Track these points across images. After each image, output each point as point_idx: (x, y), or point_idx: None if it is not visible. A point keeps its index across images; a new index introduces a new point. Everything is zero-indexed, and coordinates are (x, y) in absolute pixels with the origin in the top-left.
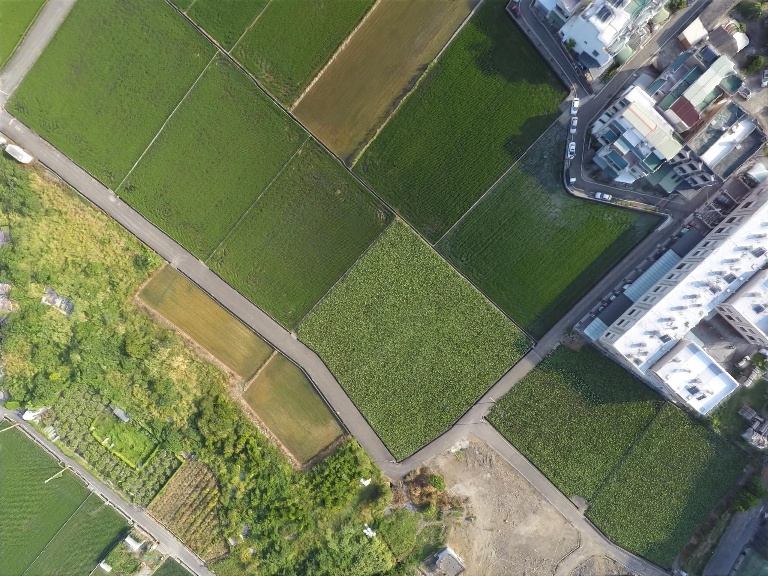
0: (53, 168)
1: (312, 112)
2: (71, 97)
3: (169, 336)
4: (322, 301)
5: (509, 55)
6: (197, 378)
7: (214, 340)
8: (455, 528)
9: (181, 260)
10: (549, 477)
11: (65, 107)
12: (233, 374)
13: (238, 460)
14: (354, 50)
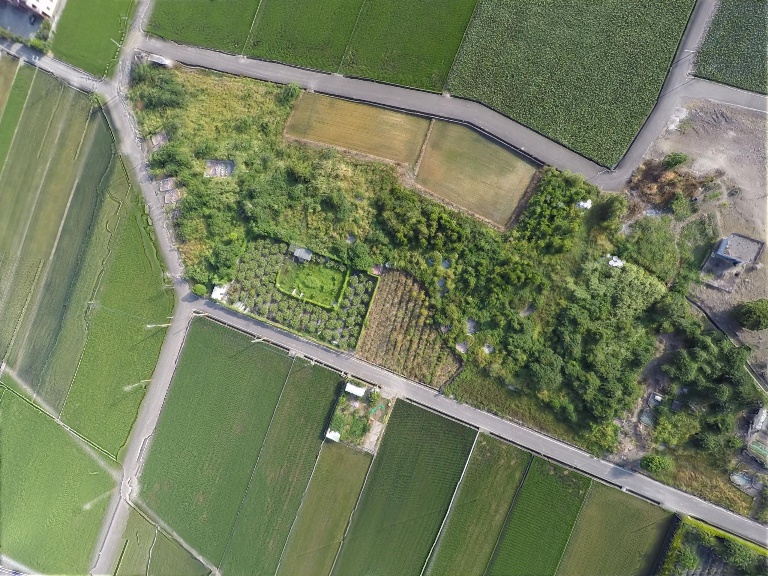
0: (187, 61)
1: None
2: (188, 0)
3: None
4: (461, 46)
5: None
6: (365, 181)
7: (369, 140)
8: (720, 212)
9: (315, 81)
10: None
11: (185, 10)
12: (398, 163)
13: (437, 240)
14: None
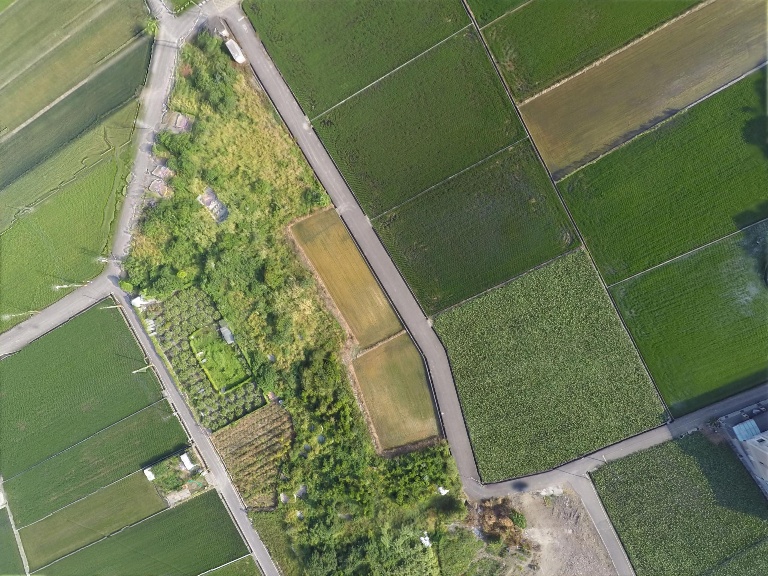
0: (261, 76)
1: (540, 115)
2: (306, 16)
3: (307, 277)
4: (473, 300)
5: (764, 131)
6: (317, 328)
7: (347, 297)
8: (514, 570)
9: (348, 209)
10: (631, 556)
11: (297, 23)
12: (353, 337)
13: (327, 422)
14: (607, 71)
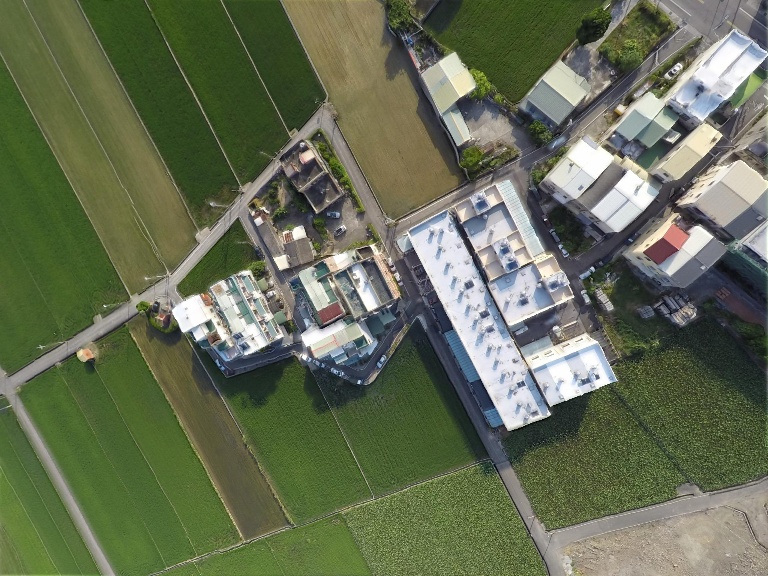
0: None
1: (249, 528)
2: None
3: None
4: None
5: (256, 387)
6: None
7: None
8: None
9: None
10: (640, 506)
11: None
12: None
13: None
14: (220, 482)
